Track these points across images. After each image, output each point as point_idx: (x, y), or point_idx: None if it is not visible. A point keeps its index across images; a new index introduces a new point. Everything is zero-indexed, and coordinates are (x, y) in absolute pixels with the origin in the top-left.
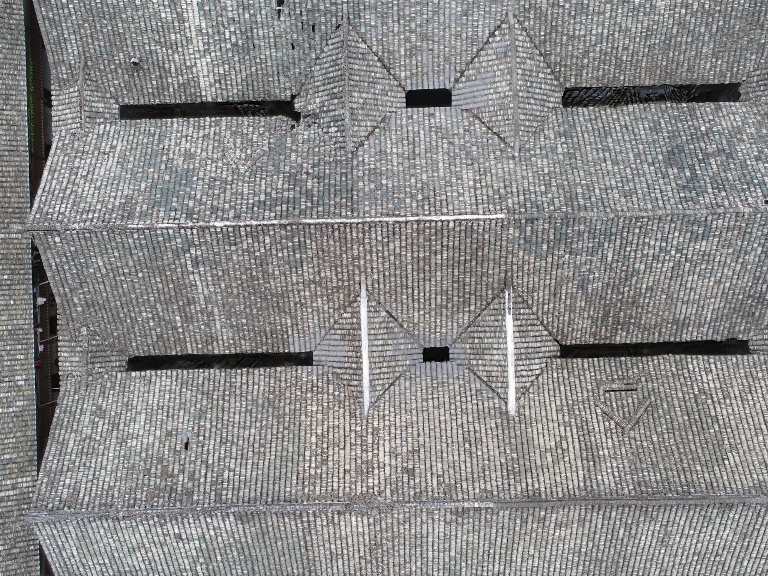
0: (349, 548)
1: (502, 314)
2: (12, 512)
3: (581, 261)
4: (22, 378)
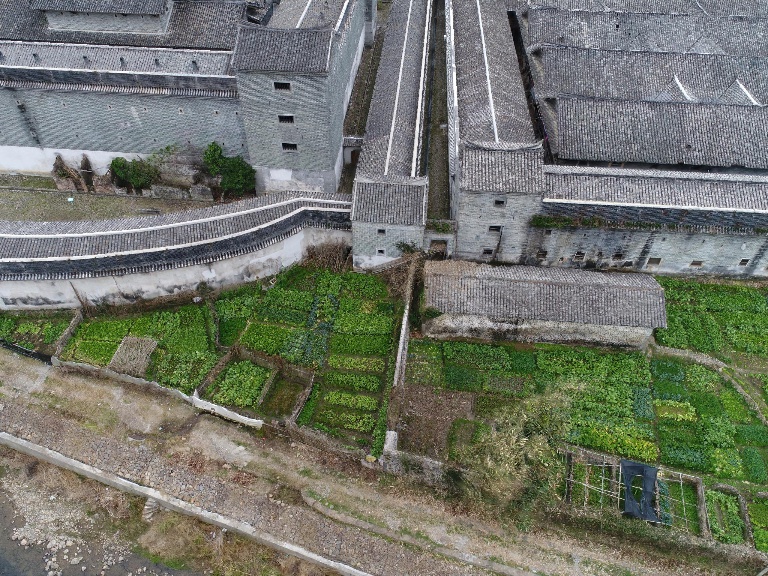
0: (702, 126)
1: (737, 86)
2: (525, 127)
3: (765, 73)
4: (522, 99)
